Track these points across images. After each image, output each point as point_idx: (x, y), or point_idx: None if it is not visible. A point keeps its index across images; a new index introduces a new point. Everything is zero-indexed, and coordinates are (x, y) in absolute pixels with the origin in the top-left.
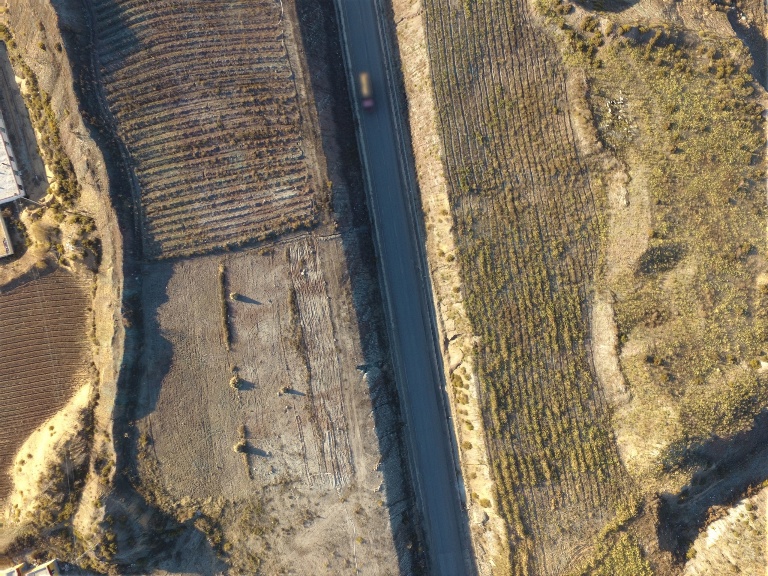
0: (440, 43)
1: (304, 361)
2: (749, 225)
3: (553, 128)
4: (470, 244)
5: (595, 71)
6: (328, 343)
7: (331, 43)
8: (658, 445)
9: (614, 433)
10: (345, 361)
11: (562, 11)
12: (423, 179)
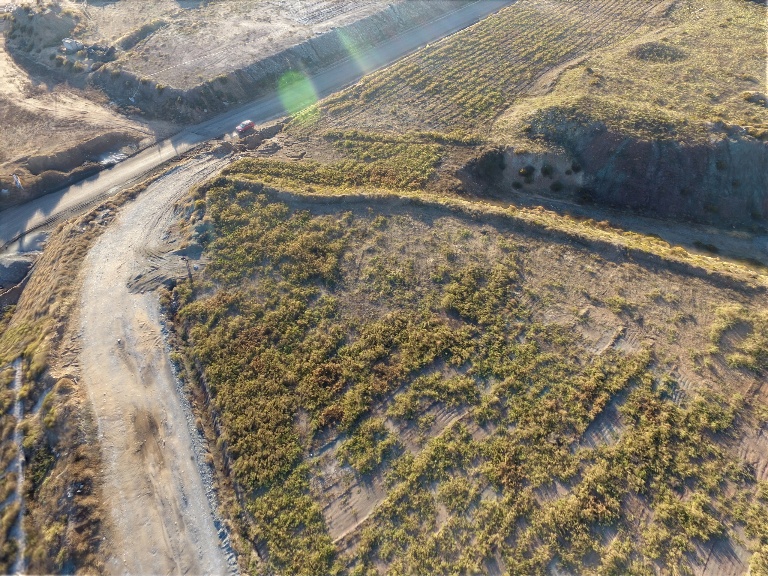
0: None
1: None
2: (763, 71)
3: (638, 5)
4: None
5: None
6: None
7: None
8: (541, 107)
9: (511, 105)
10: (387, 0)
11: None
12: None
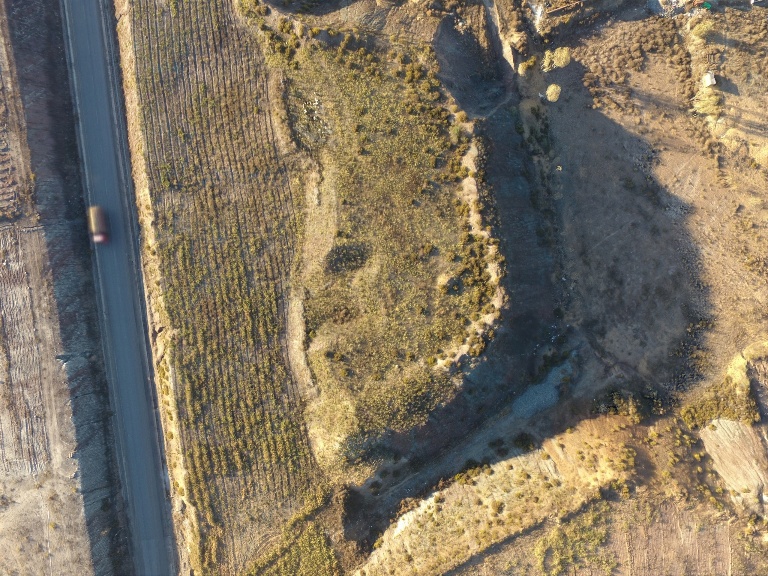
0: (145, 40)
1: (4, 350)
2: (432, 227)
3: (254, 127)
4: (170, 239)
5: (292, 72)
6: (28, 333)
7: (53, 37)
8: (338, 438)
9: (306, 426)
10: (45, 351)
11: (260, 12)
12: (136, 174)
